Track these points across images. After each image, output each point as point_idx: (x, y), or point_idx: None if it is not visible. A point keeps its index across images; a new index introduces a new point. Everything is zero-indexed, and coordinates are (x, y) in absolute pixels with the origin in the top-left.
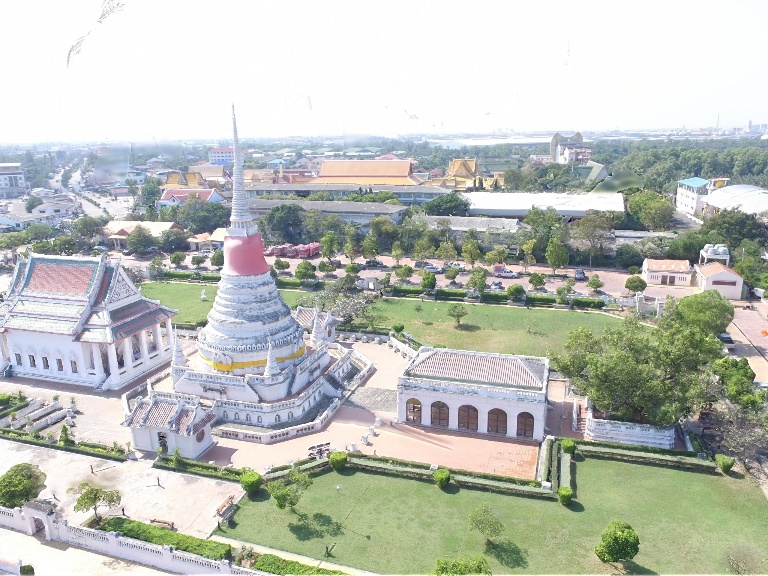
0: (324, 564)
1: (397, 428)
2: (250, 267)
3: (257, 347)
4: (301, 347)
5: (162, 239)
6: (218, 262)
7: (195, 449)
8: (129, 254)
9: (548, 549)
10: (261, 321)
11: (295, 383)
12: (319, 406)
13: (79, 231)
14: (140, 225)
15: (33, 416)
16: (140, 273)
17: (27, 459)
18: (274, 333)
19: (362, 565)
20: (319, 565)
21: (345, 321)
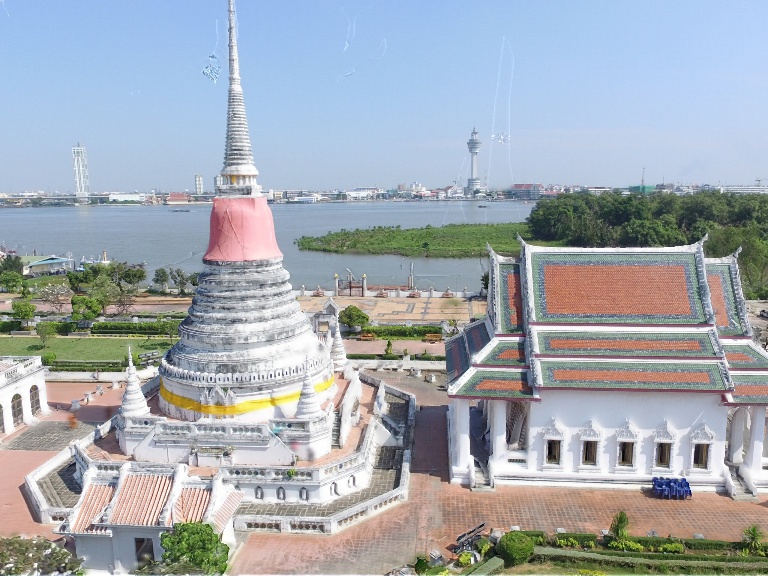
0: (152, 338)
1: (55, 406)
2: None
3: None
4: None
5: None
6: None
7: None
8: None
9: (8, 350)
10: None
11: None
12: None
13: None
14: None
15: None
16: None
17: None
18: None
19: (130, 339)
20: (155, 338)
21: None
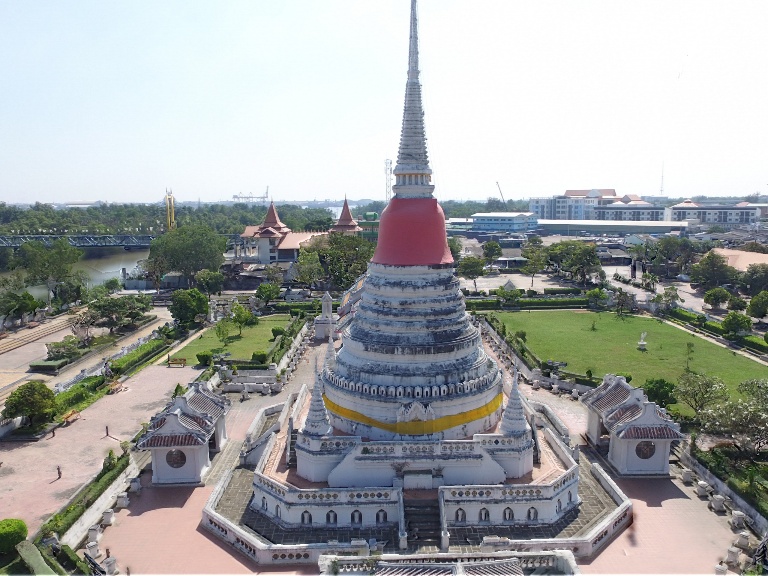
0: None
1: None
2: (389, 251)
3: (339, 382)
4: (422, 419)
5: (743, 274)
6: (754, 311)
7: (163, 472)
8: (698, 287)
9: None
10: (364, 343)
11: (339, 468)
12: (348, 534)
13: (661, 253)
14: (714, 250)
15: (255, 379)
16: (648, 304)
17: (147, 401)
18: (376, 371)
19: None
20: None
21: (736, 450)
